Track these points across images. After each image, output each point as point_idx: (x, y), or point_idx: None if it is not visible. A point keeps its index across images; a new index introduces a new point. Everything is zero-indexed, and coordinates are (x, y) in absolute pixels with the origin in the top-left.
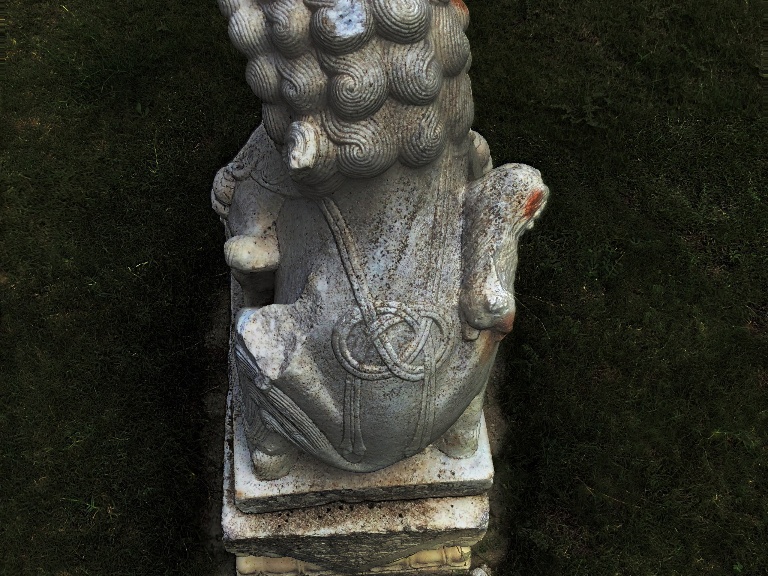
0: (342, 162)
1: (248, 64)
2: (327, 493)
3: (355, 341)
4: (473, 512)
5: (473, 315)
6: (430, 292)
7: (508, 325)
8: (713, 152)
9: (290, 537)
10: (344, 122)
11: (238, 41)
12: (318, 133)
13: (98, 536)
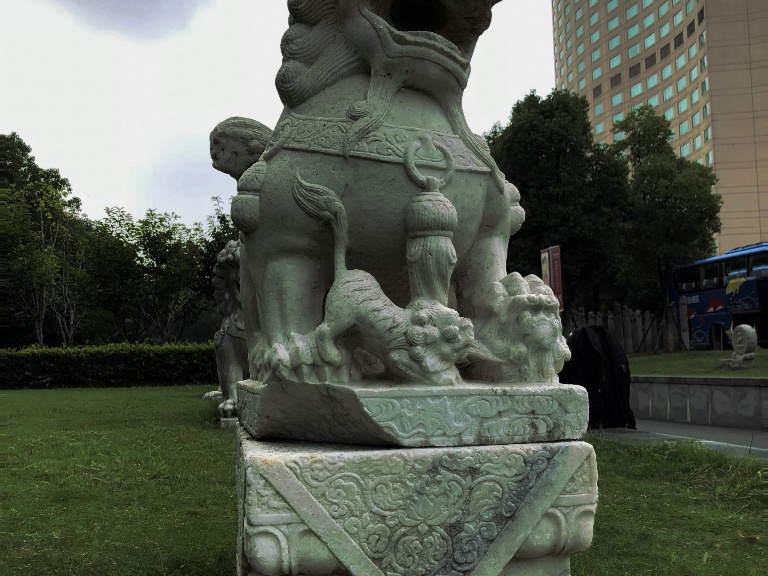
0: None
1: None
2: None
3: None
4: None
5: None
6: None
7: None
8: None
9: None
10: None
11: None
12: None
13: (611, 569)
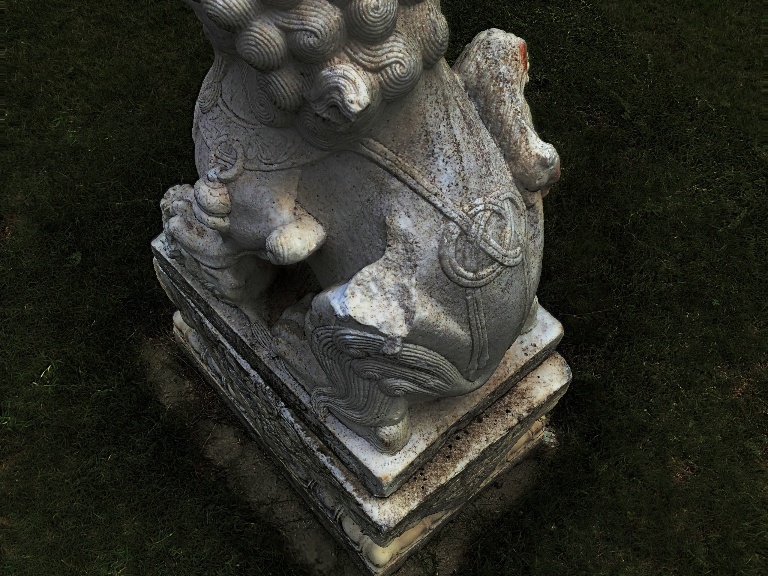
0: (387, 87)
1: (239, 38)
2: (449, 429)
3: (463, 255)
4: (557, 371)
5: (533, 179)
6: (495, 176)
7: (558, 173)
8: (467, 5)
9: (436, 491)
10: (374, 46)
11: (227, 15)
12: (354, 69)
13: None
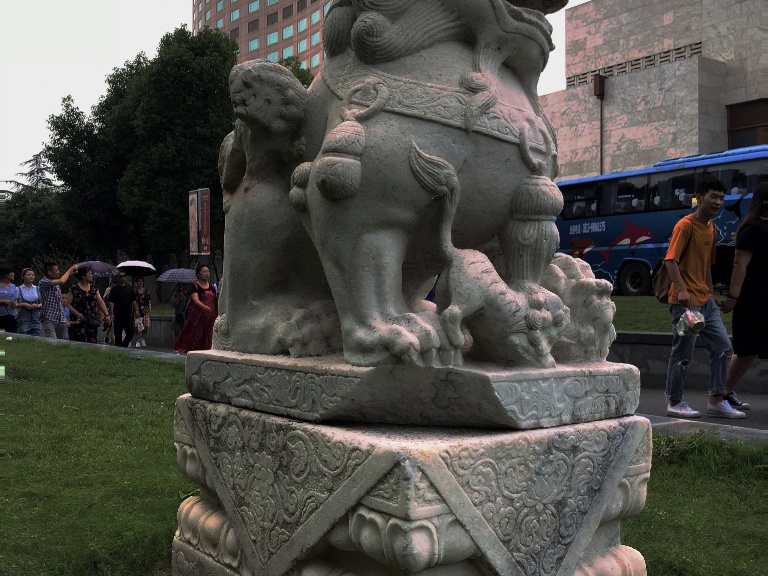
0: None
1: None
2: None
3: None
4: None
5: None
6: None
7: None
8: None
9: None
10: None
11: None
12: None
13: None
